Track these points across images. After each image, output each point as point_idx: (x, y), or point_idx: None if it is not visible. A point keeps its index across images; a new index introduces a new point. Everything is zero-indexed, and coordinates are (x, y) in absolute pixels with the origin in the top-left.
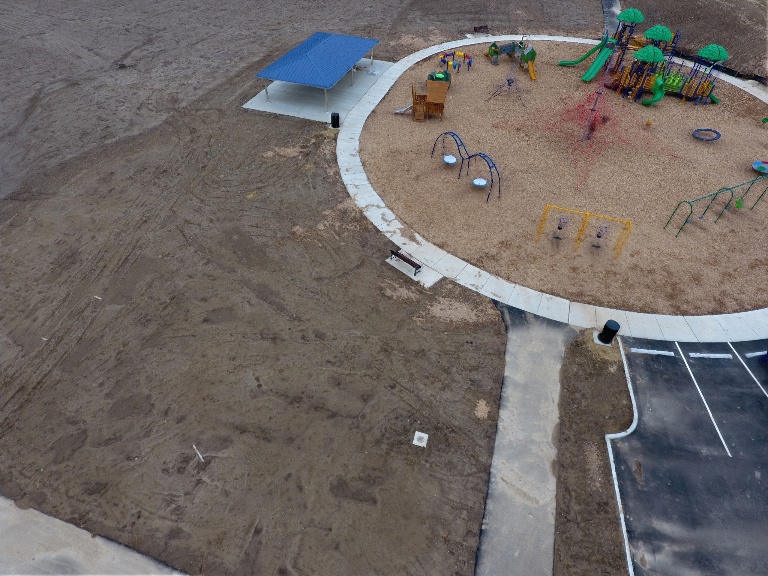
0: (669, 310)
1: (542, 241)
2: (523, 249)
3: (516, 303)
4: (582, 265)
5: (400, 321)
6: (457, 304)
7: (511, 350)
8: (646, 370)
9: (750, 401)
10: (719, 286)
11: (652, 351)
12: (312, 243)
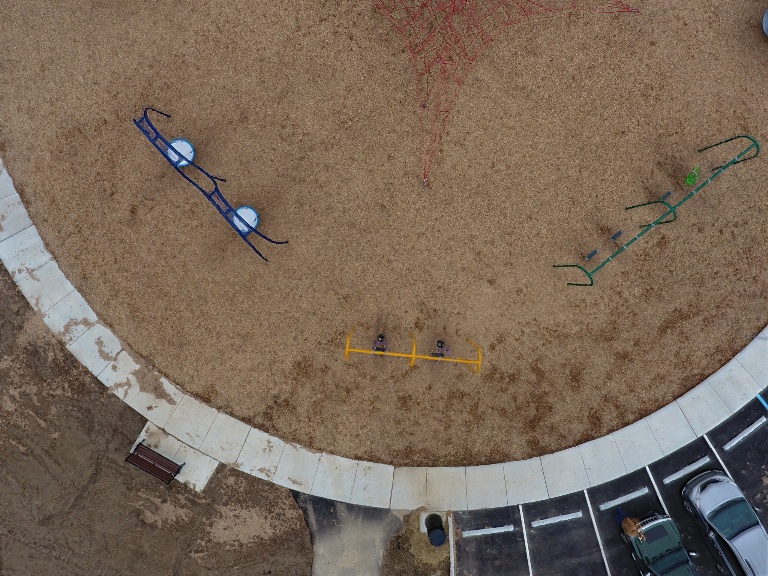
0: (523, 452)
1: (359, 347)
2: (330, 374)
3: (322, 490)
4: (416, 389)
5: (175, 565)
6: (244, 513)
7: (318, 572)
8: (476, 559)
9: (583, 572)
10: (603, 386)
11: (487, 532)
12: (8, 449)
